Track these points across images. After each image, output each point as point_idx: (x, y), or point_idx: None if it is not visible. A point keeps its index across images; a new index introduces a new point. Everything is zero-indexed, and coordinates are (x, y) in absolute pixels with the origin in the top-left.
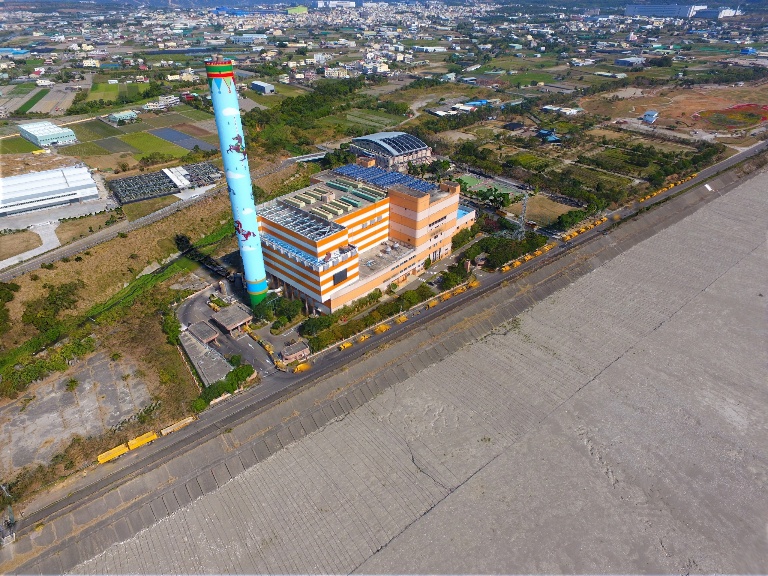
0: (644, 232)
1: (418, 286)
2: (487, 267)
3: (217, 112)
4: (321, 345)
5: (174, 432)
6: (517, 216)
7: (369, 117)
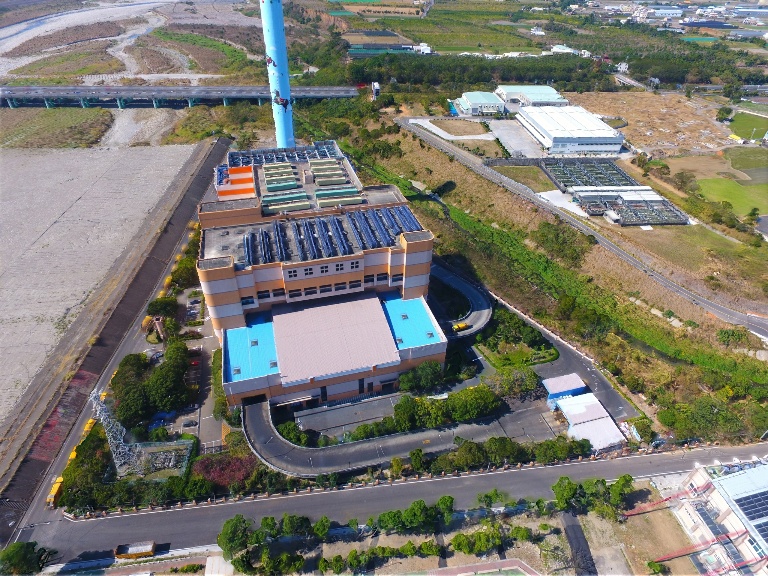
0: None
1: None
2: None
3: None
4: None
5: None
6: (190, 564)
7: None
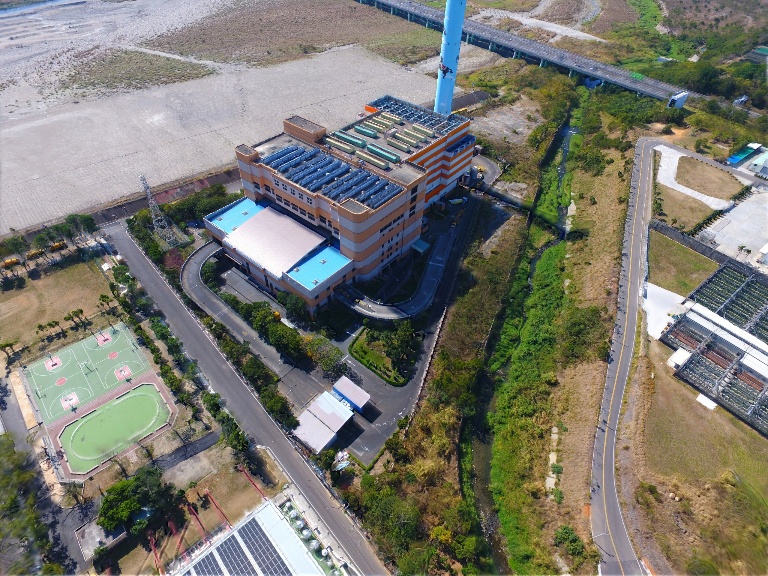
0: None
1: None
2: None
3: None
4: None
5: None
6: None
7: None
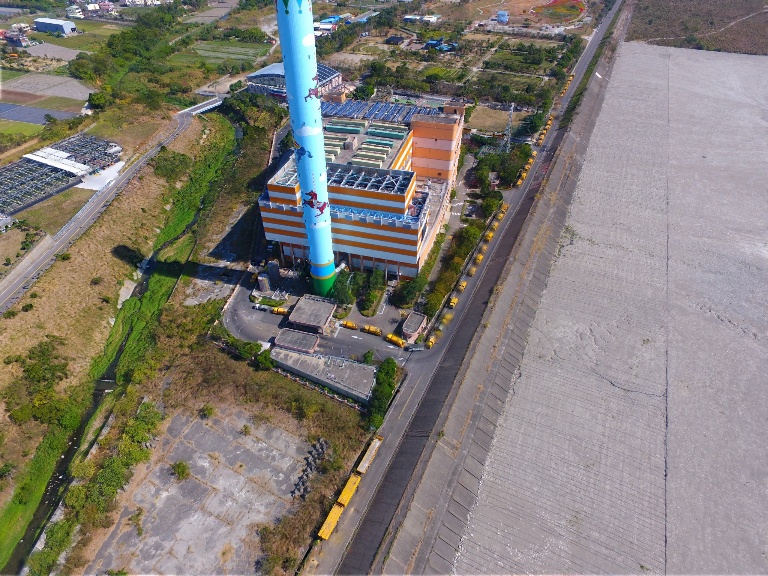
0: (589, 123)
1: (459, 221)
2: (502, 185)
3: (294, 42)
4: (436, 309)
5: (371, 464)
6: (481, 130)
7: (226, 49)
